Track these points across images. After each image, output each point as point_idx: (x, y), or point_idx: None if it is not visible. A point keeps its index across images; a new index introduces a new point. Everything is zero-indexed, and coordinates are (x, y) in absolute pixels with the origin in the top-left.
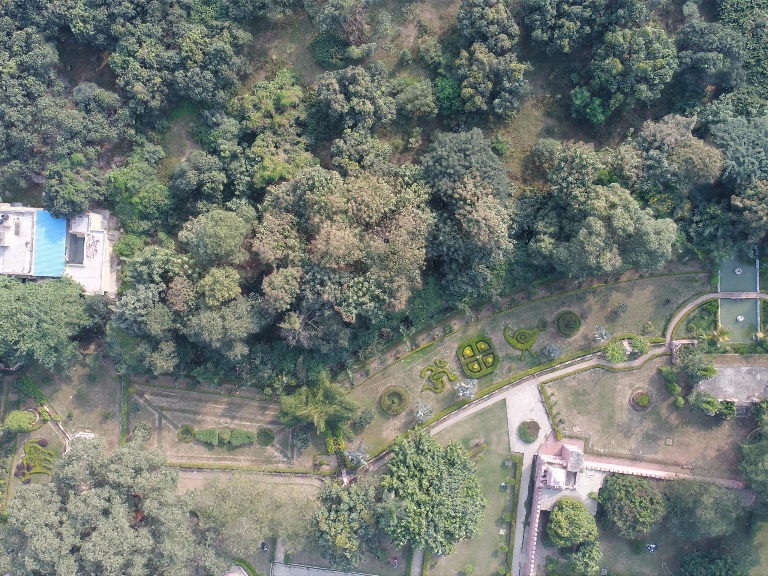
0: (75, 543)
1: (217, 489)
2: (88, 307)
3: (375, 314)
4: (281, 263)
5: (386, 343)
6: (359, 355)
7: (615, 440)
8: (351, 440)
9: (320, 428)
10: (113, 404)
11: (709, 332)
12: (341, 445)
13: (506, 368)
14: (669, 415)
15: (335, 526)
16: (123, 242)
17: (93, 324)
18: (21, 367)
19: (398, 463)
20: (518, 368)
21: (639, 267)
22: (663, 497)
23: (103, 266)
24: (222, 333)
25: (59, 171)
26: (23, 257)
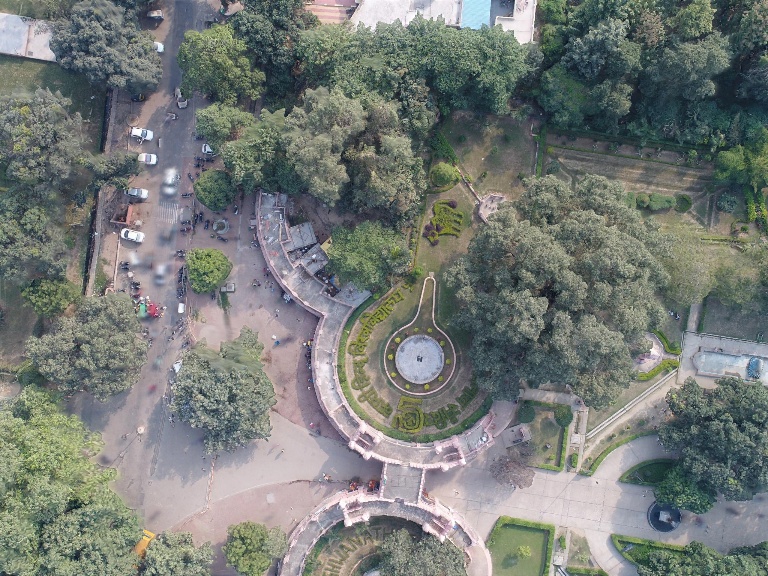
0: (570, 259)
1: None
2: None
3: None
4: (746, 5)
5: None
6: None
7: None
8: None
9: (767, 181)
10: (526, 167)
11: None
12: (764, 211)
13: None
14: None
15: None
16: None
17: (527, 74)
18: (436, 125)
19: None
20: None
21: None
22: None
23: (534, 19)
24: None
25: None
26: (450, 9)
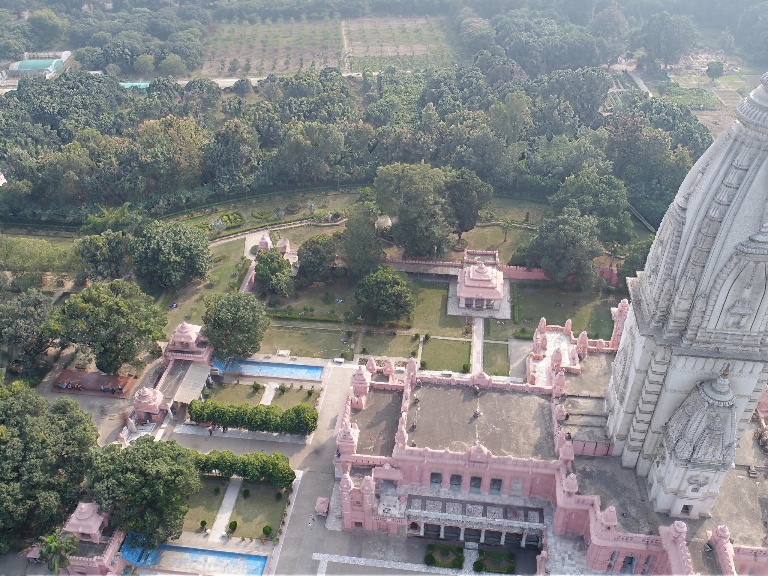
0: None
1: None
2: None
3: (164, 170)
4: None
5: (172, 213)
6: None
7: None
8: None
9: None
10: None
11: None
12: None
13: (249, 226)
14: None
15: None
16: None
17: None
18: None
19: None
20: None
21: (340, 188)
22: None
23: None
24: (66, 161)
25: (7, 142)
26: None
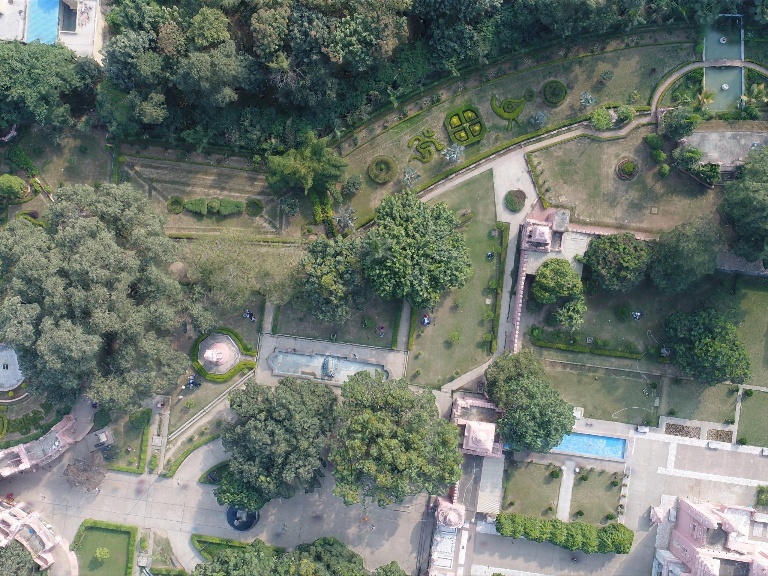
0: (63, 266)
1: (205, 241)
2: (80, 68)
3: (362, 61)
4: None
5: (374, 111)
6: (347, 119)
7: (601, 209)
8: (339, 202)
9: (308, 184)
10: (104, 176)
11: (694, 101)
12: (329, 213)
13: (493, 138)
14: (654, 184)
15: (321, 268)
16: (115, 12)
17: (84, 87)
18: (13, 138)
19: (384, 216)
20: (505, 138)
21: (625, 36)
22: (647, 247)
23: (95, 33)
24: (211, 72)
25: None
26: (16, 25)
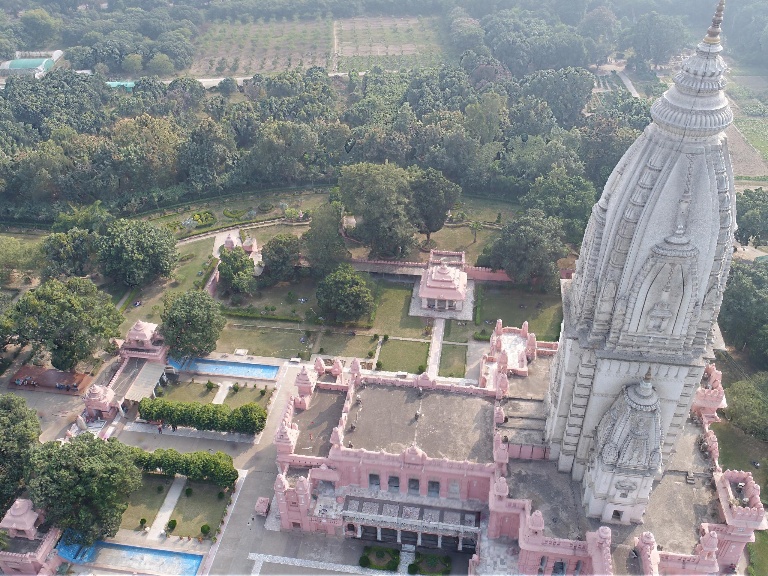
0: None
1: None
2: None
3: (137, 168)
4: None
5: (145, 212)
6: None
7: None
8: None
9: None
10: None
11: None
12: None
13: (220, 225)
14: None
15: None
16: None
17: None
18: None
19: None
20: None
21: None
22: None
23: None
24: (39, 159)
25: None
26: None
